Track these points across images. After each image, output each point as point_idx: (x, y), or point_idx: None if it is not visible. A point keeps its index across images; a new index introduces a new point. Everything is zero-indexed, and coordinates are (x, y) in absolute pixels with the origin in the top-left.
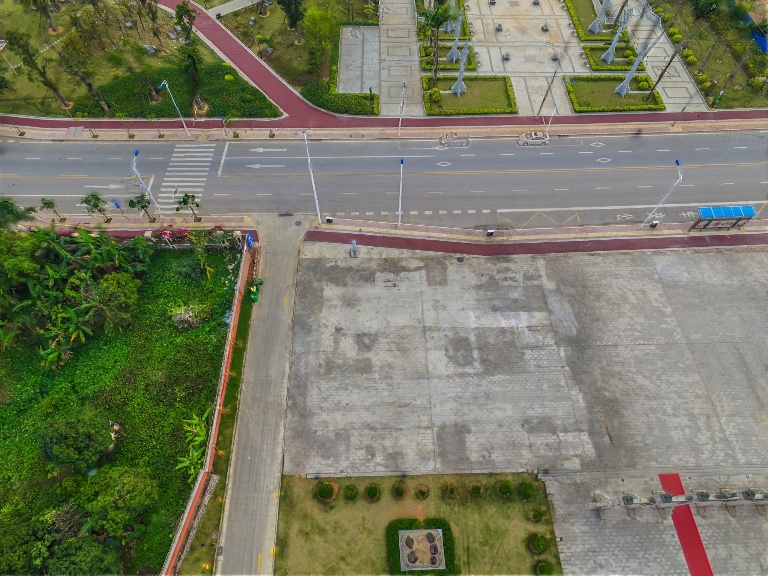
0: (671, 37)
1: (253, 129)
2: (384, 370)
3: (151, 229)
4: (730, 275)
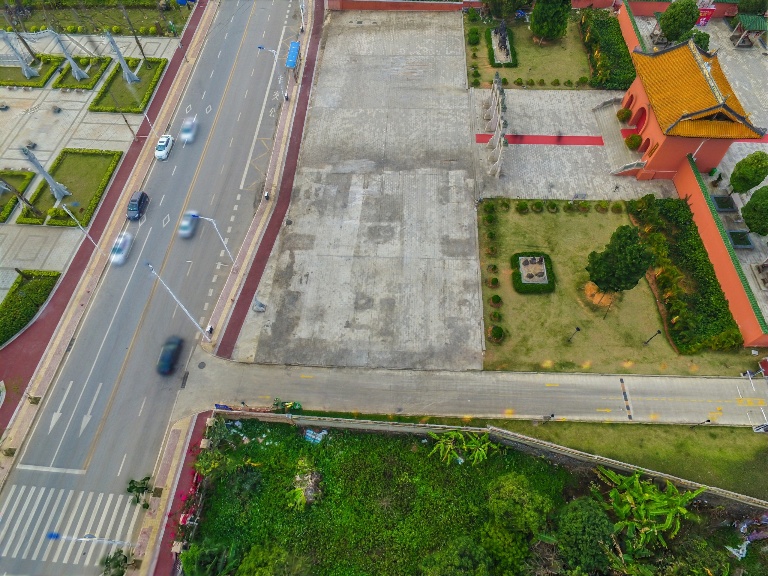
0: (77, 33)
1: (8, 428)
2: (393, 289)
3: (154, 563)
4: (338, 75)
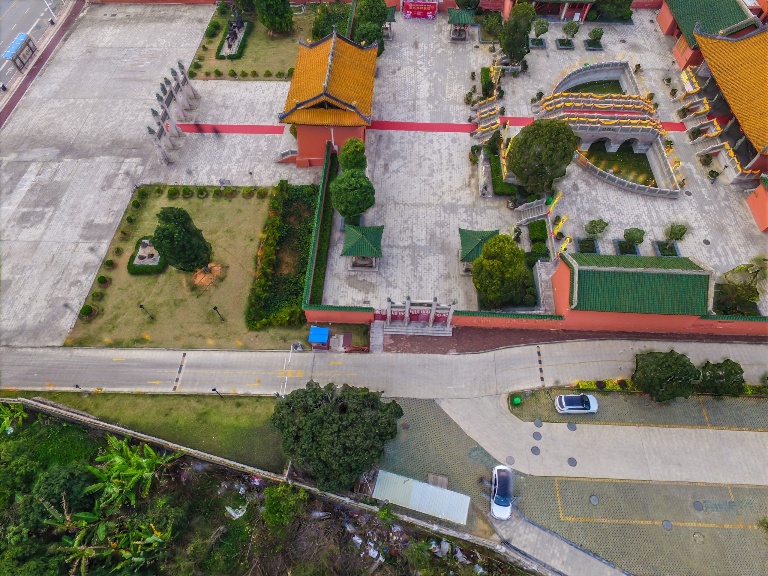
0: None
1: None
2: (16, 271)
3: None
4: (67, 66)
